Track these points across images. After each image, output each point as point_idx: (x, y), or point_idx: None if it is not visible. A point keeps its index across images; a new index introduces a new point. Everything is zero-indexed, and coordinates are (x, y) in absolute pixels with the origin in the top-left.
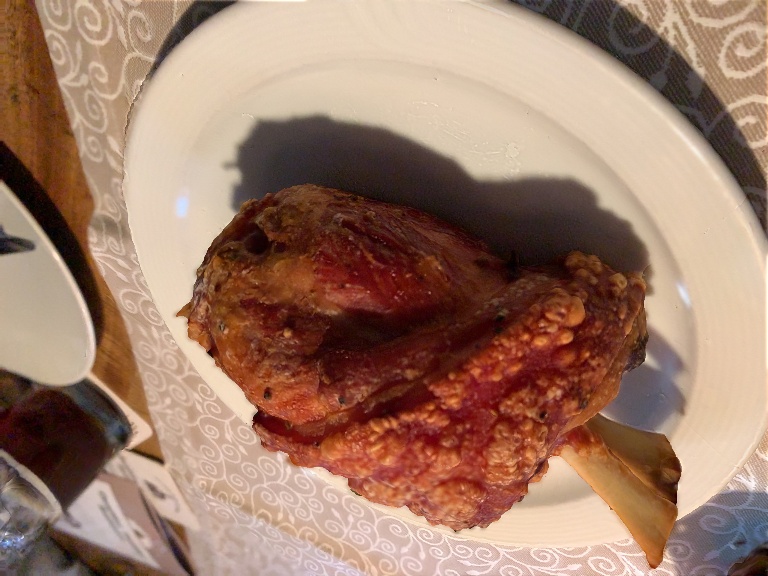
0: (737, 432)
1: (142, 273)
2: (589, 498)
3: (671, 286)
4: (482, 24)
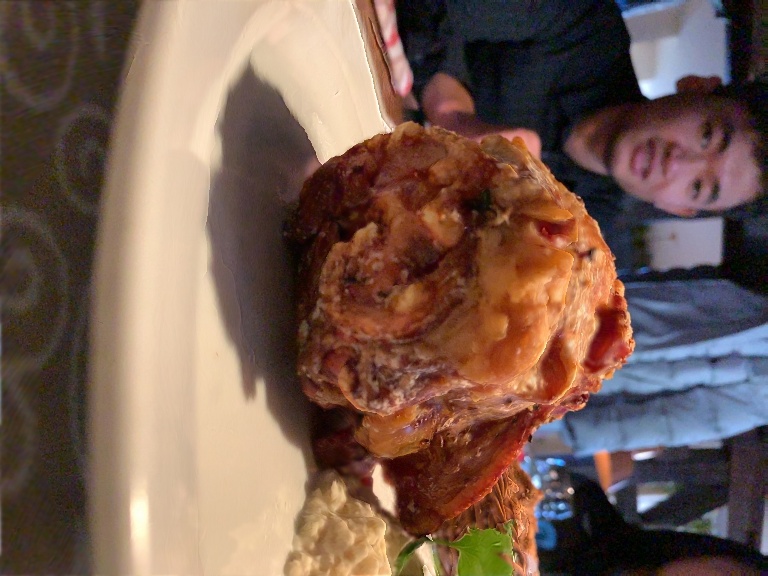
0: None
1: (118, 532)
2: None
3: None
4: (364, 61)
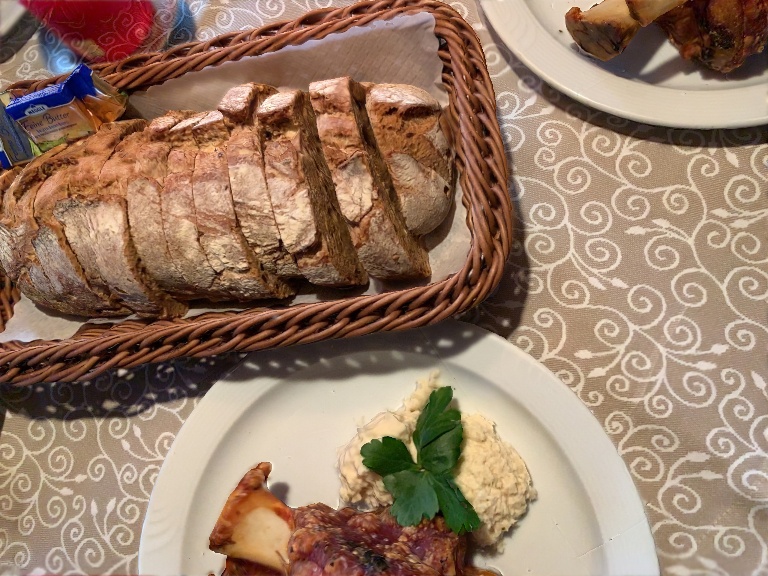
0: (611, 98)
1: None
2: (528, 9)
3: (718, 86)
4: None
